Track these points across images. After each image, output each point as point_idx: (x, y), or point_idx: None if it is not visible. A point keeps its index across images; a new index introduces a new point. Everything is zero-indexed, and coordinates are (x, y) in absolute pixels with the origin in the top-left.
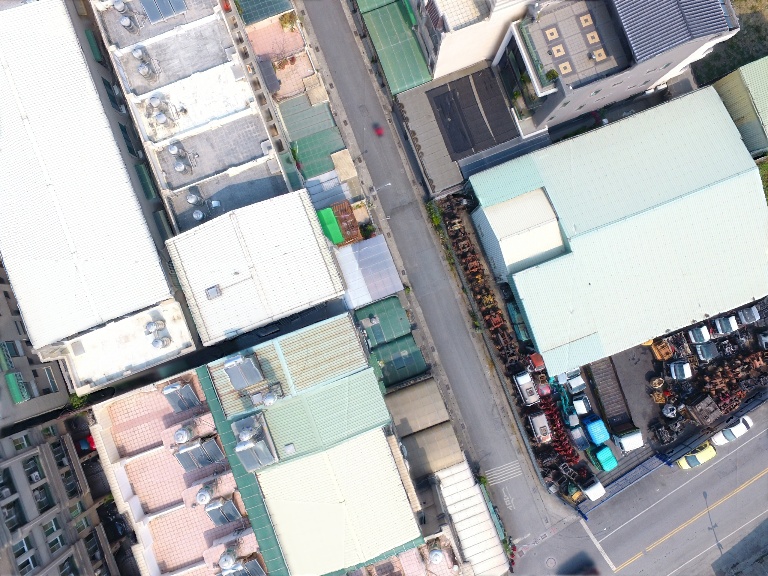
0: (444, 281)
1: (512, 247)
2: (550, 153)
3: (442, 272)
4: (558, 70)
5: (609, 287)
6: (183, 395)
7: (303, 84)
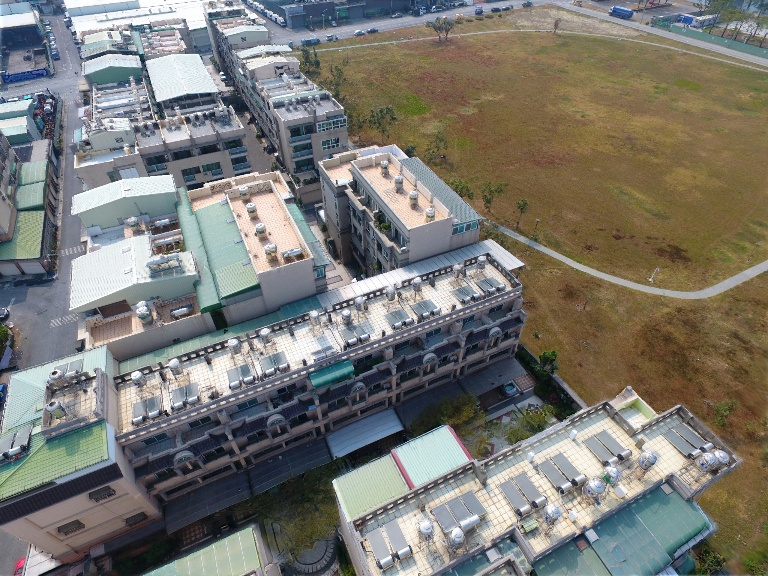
0: None
1: None
2: None
3: None
4: None
5: None
6: None
7: None
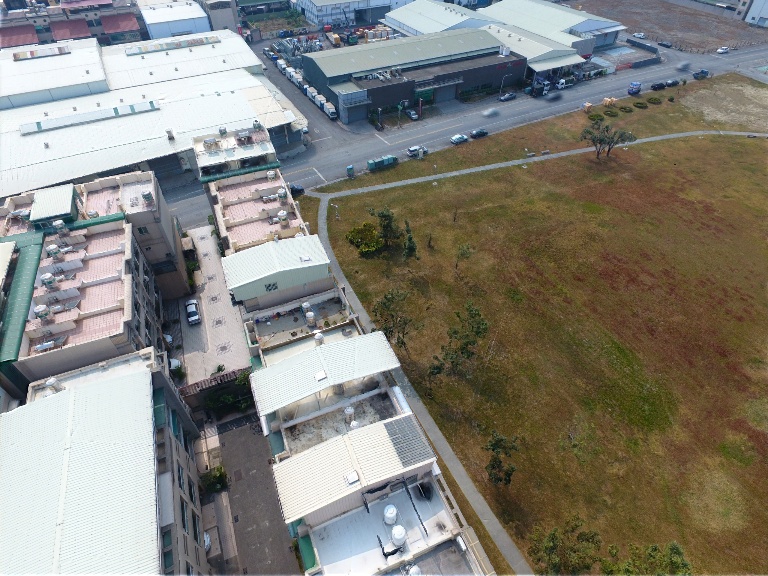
0: None
1: None
2: None
3: None
4: None
5: None
6: None
7: None
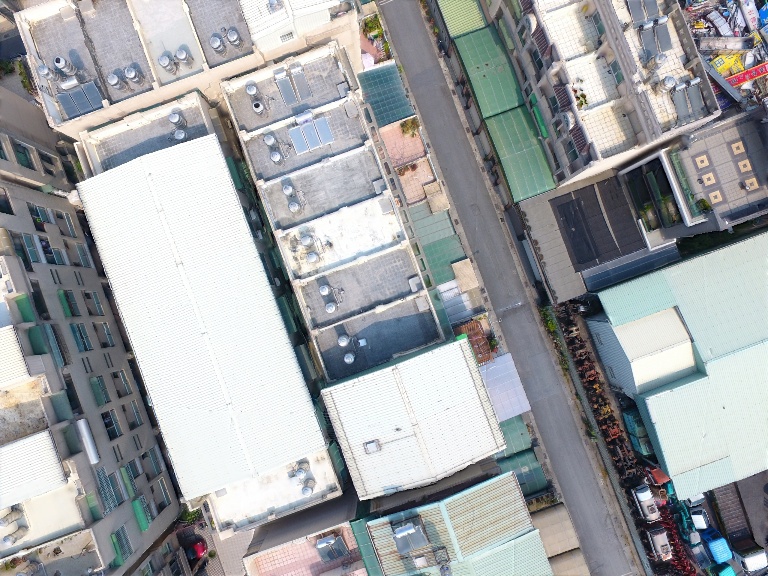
0: (557, 386)
1: (643, 368)
2: (682, 270)
3: (555, 377)
4: (708, 199)
5: (743, 411)
6: (334, 546)
7: (423, 191)
